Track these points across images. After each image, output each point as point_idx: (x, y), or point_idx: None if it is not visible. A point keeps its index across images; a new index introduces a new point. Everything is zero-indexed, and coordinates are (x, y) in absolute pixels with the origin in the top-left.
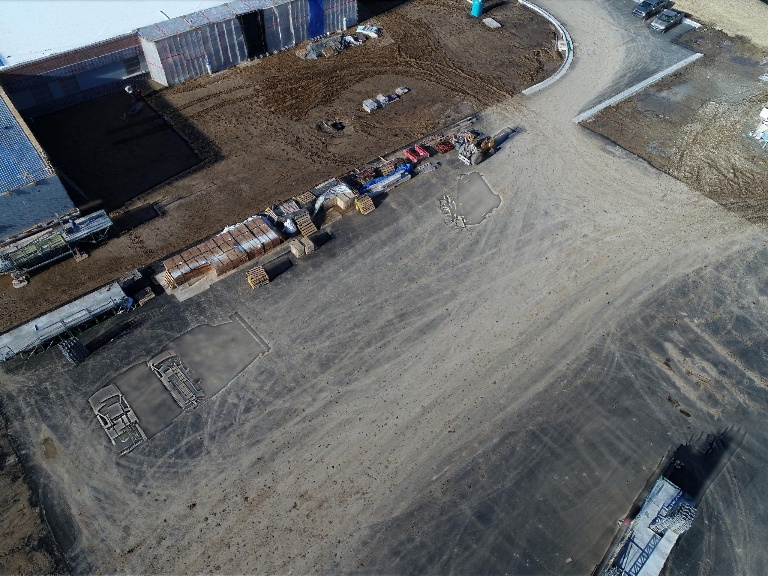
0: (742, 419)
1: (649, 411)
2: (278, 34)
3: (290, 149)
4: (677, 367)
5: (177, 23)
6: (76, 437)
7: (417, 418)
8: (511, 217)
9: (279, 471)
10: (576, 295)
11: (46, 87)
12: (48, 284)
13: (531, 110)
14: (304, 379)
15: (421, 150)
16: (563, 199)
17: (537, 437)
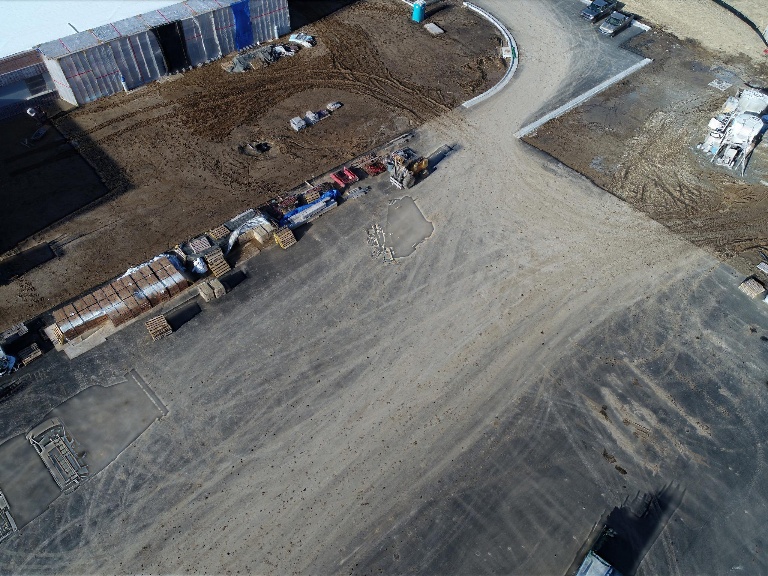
0: (682, 474)
1: (582, 469)
2: (201, 46)
3: (208, 175)
4: (614, 416)
5: (84, 38)
6: None
7: (327, 489)
8: (443, 247)
9: (166, 562)
10: (509, 336)
11: None
12: None
13: (471, 125)
14: (203, 447)
15: (350, 173)
16: (500, 225)
17: (459, 506)
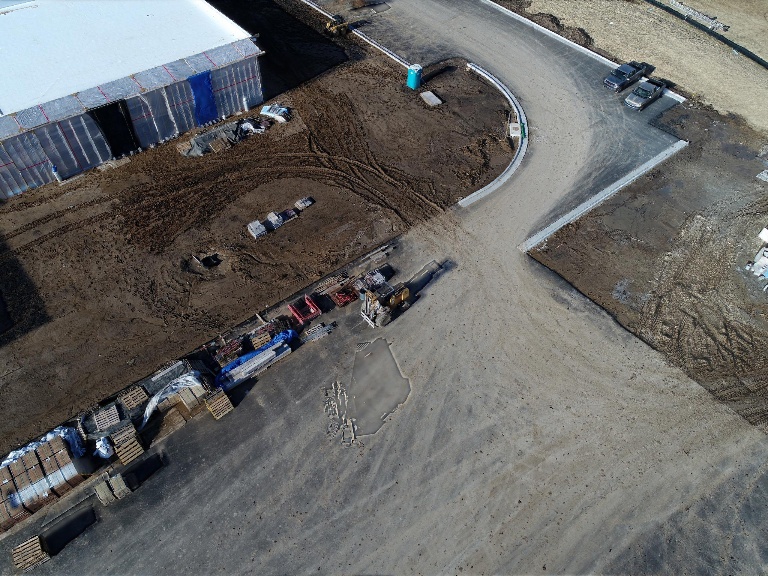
0: None
1: None
2: (153, 125)
3: (138, 302)
4: None
5: (3, 124)
6: None
7: None
8: (421, 420)
9: None
10: (499, 573)
11: None
12: None
13: (466, 232)
14: None
15: (311, 305)
16: (495, 385)
17: None
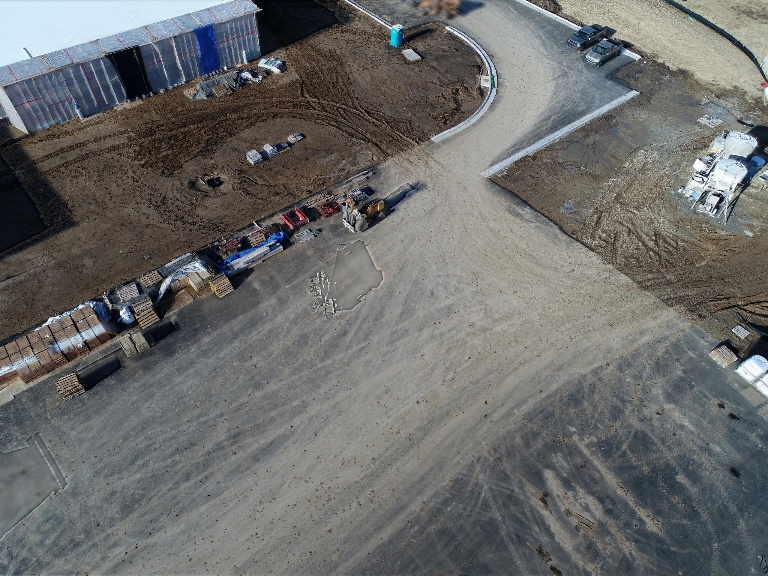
0: None
1: (512, 569)
2: (163, 72)
3: (152, 212)
4: (555, 504)
5: (34, 64)
6: None
7: None
8: (390, 300)
9: None
10: (449, 405)
11: None
12: None
13: (437, 161)
14: (98, 528)
15: (300, 214)
16: (454, 276)
17: None
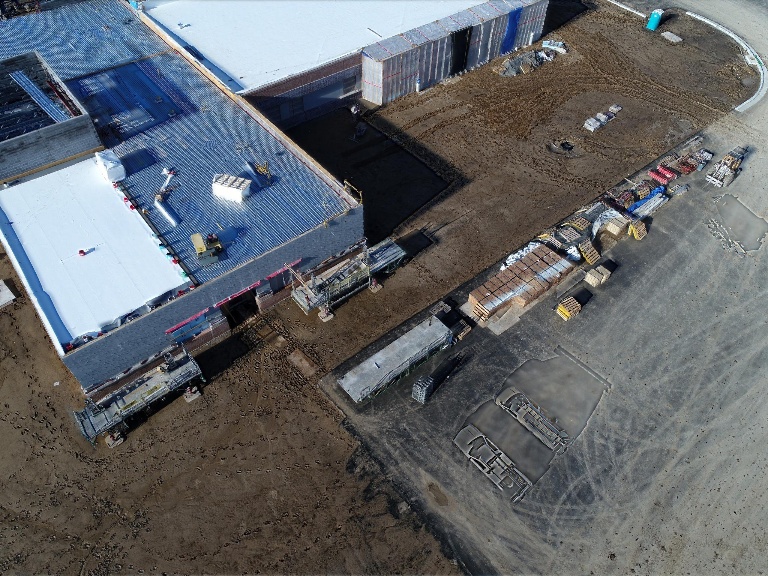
0: None
1: None
2: (477, 50)
3: (531, 171)
4: None
5: (398, 41)
6: (460, 482)
7: None
8: None
9: (683, 518)
10: None
11: (277, 108)
12: (355, 317)
13: (753, 128)
14: (661, 417)
15: (667, 172)
16: None
17: None
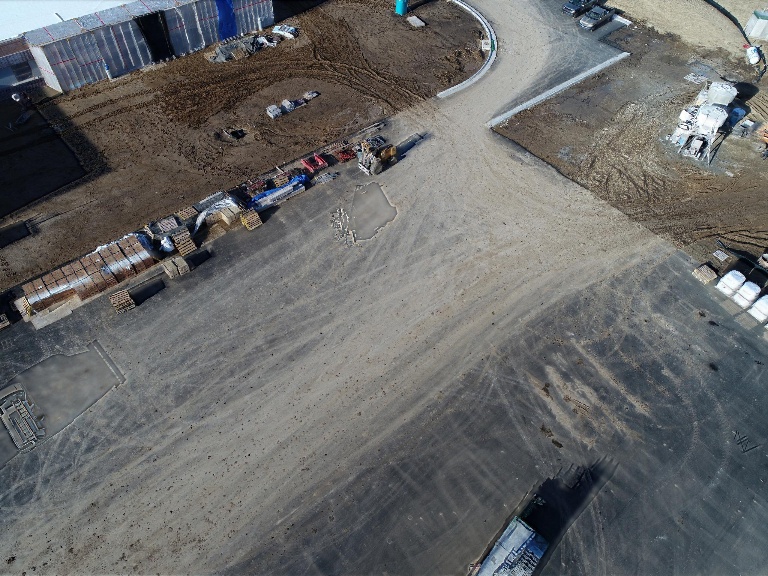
0: (616, 449)
1: (519, 442)
2: (184, 36)
3: (183, 160)
4: (555, 393)
5: (68, 26)
6: None
7: (270, 455)
8: (405, 231)
9: (112, 518)
10: (460, 315)
11: None
12: None
13: (443, 115)
14: (156, 414)
15: (319, 159)
16: (462, 211)
17: (396, 473)
